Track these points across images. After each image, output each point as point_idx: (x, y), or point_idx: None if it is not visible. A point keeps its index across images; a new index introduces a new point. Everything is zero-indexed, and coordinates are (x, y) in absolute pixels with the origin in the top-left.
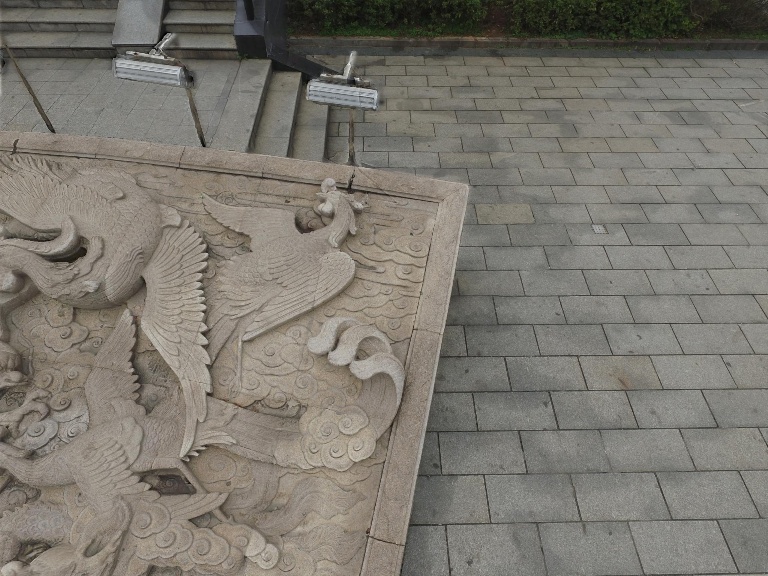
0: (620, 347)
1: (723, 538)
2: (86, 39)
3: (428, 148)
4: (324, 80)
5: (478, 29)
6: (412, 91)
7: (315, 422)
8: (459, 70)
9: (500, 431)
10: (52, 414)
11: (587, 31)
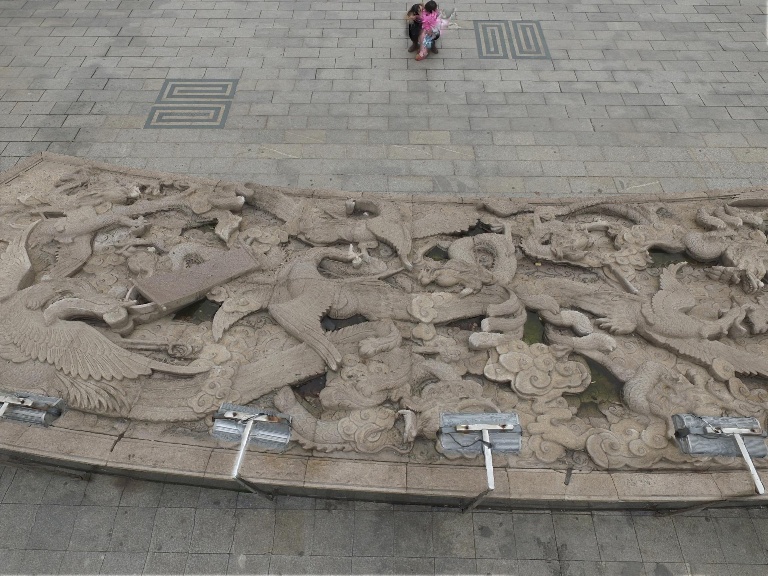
0: None
1: None
2: None
3: None
4: None
5: None
6: None
7: None
8: None
9: None
10: None
11: None
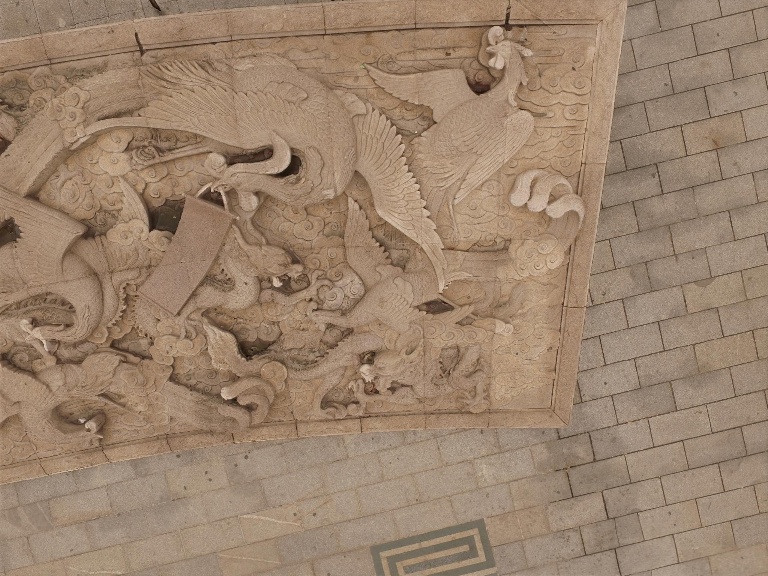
0: (718, 108)
1: (766, 244)
2: None
3: None
4: None
5: None
6: None
7: (521, 250)
8: None
9: (619, 205)
10: (334, 284)
11: None
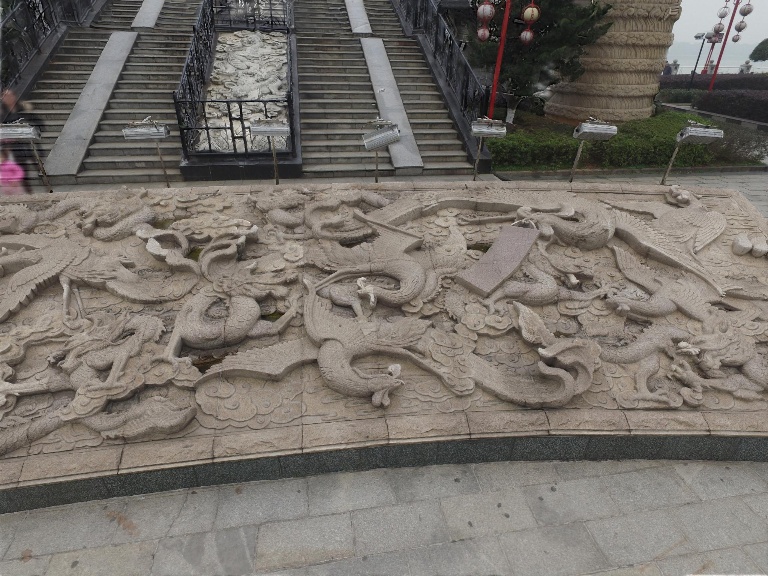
0: None
1: None
2: (372, 166)
3: None
4: (693, 127)
5: (581, 165)
6: None
7: None
8: None
9: None
10: None
11: (647, 164)
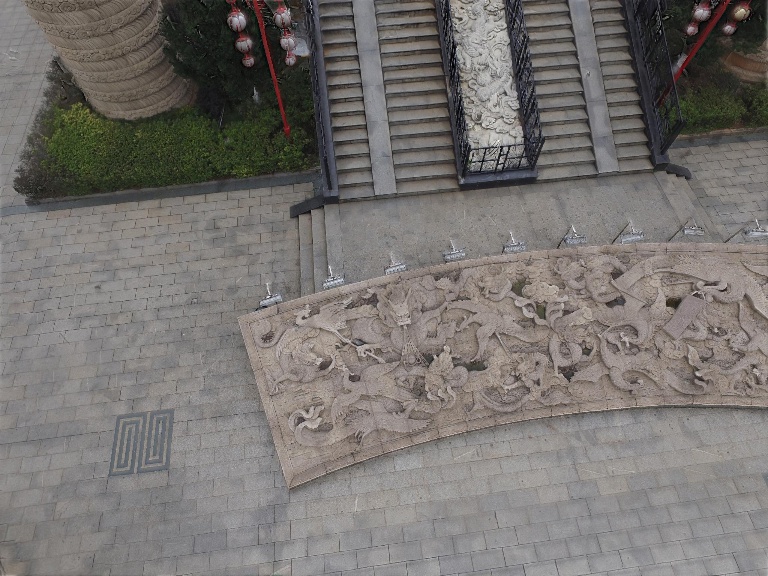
0: None
1: None
2: (582, 170)
3: (745, 210)
4: None
5: (731, 124)
6: (718, 173)
7: None
8: (731, 155)
9: None
10: None
11: None
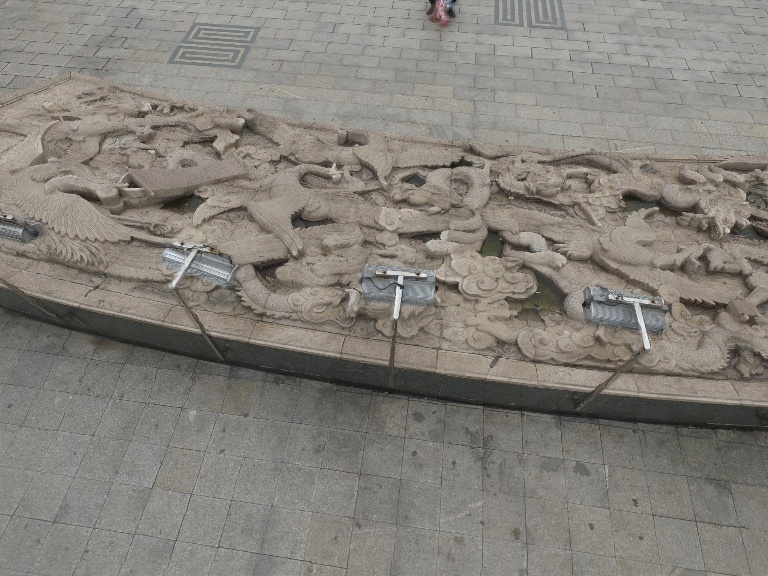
0: None
1: None
2: None
3: None
4: None
5: None
6: None
7: None
8: None
9: None
10: None
11: None
